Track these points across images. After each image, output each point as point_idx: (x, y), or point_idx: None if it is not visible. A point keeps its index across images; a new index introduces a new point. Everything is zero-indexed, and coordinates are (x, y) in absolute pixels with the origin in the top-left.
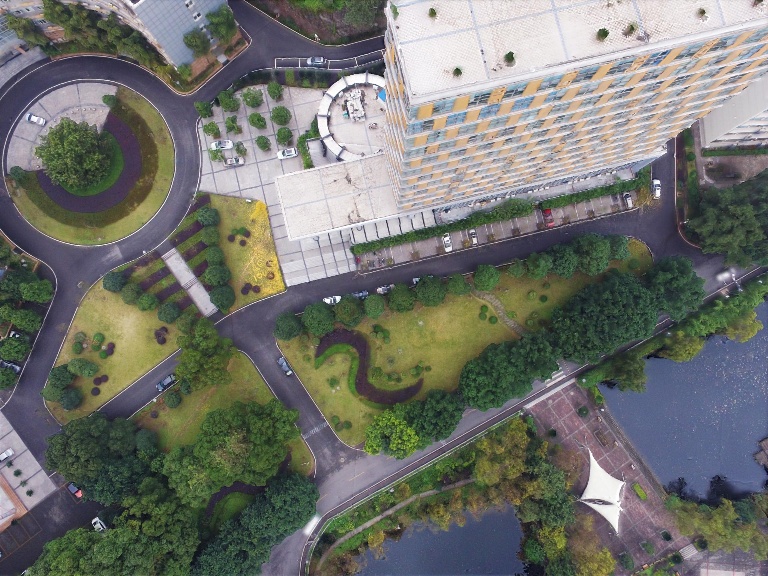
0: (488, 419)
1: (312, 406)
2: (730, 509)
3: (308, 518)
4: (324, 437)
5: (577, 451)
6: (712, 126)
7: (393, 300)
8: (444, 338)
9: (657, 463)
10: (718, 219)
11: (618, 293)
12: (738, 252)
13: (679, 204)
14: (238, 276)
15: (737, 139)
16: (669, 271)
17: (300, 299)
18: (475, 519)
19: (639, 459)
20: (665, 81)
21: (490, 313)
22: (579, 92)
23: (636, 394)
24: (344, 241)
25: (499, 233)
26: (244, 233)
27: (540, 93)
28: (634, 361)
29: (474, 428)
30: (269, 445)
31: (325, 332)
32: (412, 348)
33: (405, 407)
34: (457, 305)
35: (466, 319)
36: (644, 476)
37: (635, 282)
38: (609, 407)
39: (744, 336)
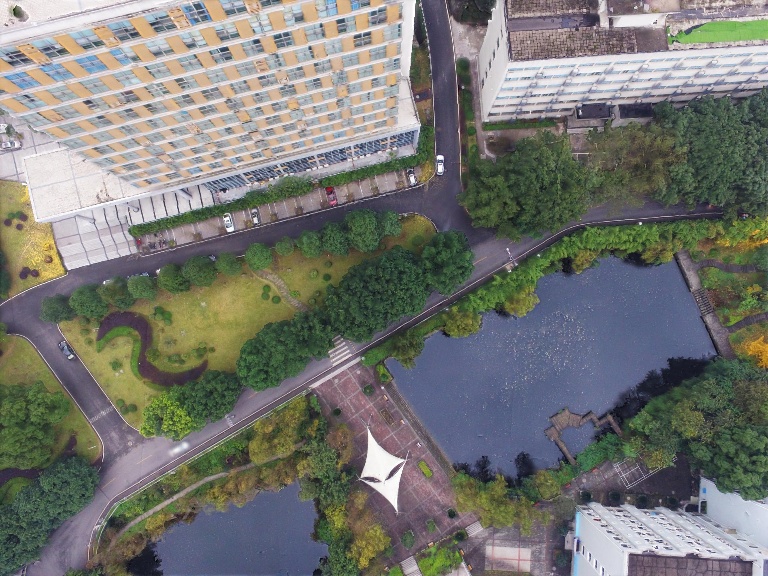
0: (274, 400)
1: (97, 390)
2: (500, 484)
3: (83, 501)
4: (111, 421)
5: (363, 430)
6: (485, 99)
7: (158, 280)
8: (227, 319)
9: (446, 441)
10: (477, 192)
11: (383, 269)
12: (506, 225)
13: (463, 179)
14: (16, 260)
15: (511, 112)
16: (436, 246)
17: (81, 282)
18: (269, 501)
19: (427, 437)
20: (261, 40)
21: (273, 293)
22: (153, 51)
23: (431, 372)
24: (122, 223)
25: (283, 212)
26: (20, 217)
27: (93, 51)
28: (404, 337)
29: (260, 409)
30: (23, 427)
31: (98, 314)
32: (195, 330)
33: (181, 388)
34: (240, 285)
35: (249, 299)
36: (431, 454)
37: (406, 258)
38: (398, 385)
39: (518, 310)
